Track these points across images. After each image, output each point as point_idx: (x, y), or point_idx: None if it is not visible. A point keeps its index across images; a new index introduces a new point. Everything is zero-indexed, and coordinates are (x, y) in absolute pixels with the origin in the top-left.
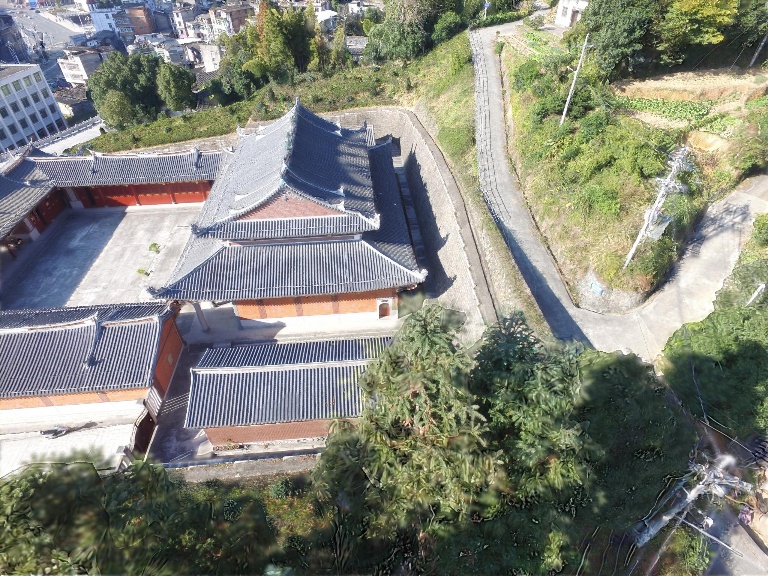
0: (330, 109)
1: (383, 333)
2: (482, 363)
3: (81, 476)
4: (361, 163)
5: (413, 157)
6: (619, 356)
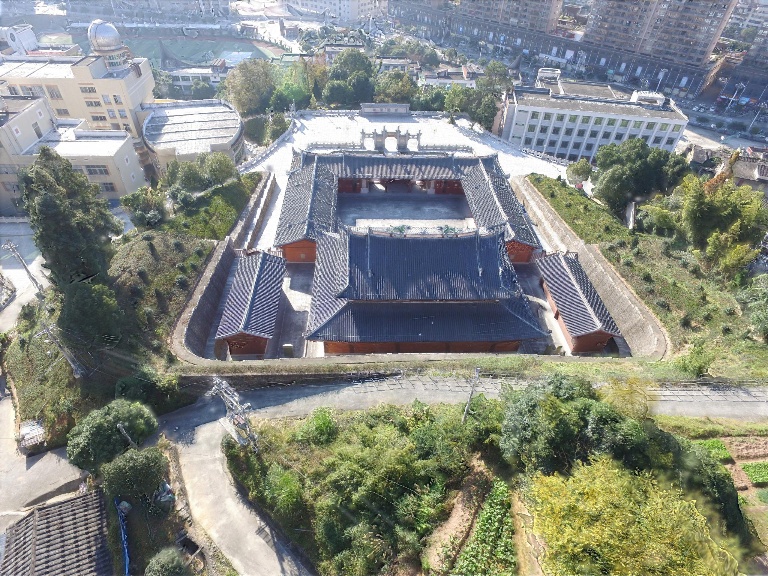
0: None
1: (313, 351)
2: None
3: (52, 155)
4: (438, 291)
5: None
6: (88, 291)
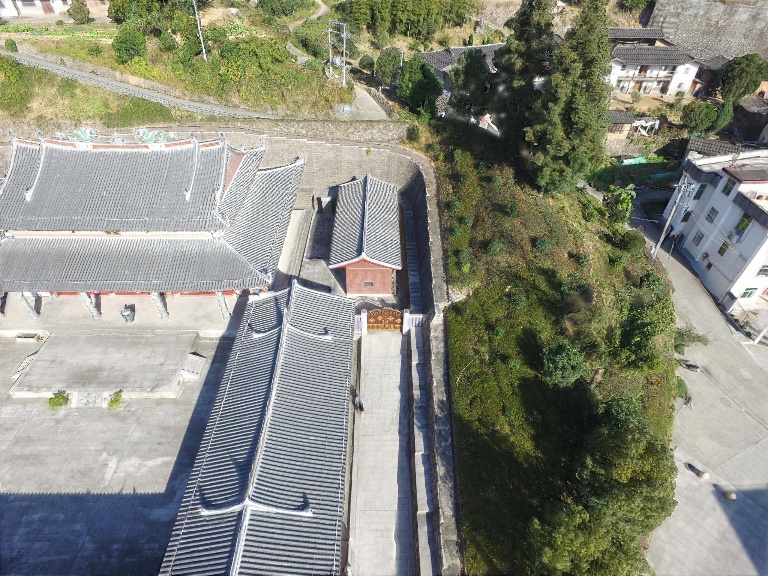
0: None
1: (303, 223)
2: (531, 7)
3: None
4: None
5: None
6: None
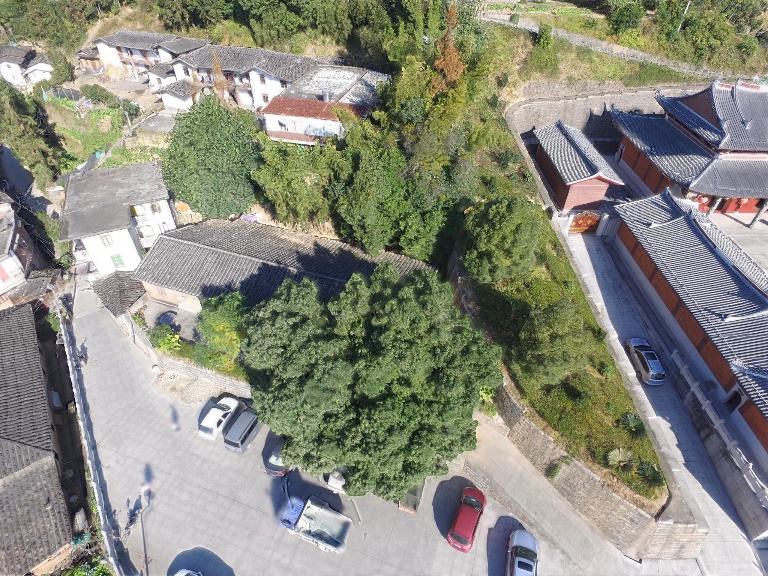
0: None
1: None
2: None
3: None
4: None
5: (607, 116)
6: None
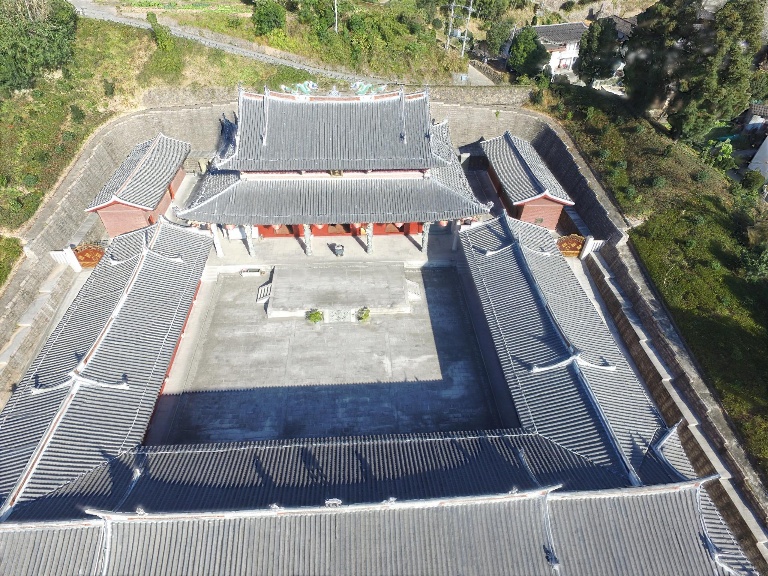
0: (70, 156)
1: None
2: None
3: None
4: None
5: None
6: (597, 21)
